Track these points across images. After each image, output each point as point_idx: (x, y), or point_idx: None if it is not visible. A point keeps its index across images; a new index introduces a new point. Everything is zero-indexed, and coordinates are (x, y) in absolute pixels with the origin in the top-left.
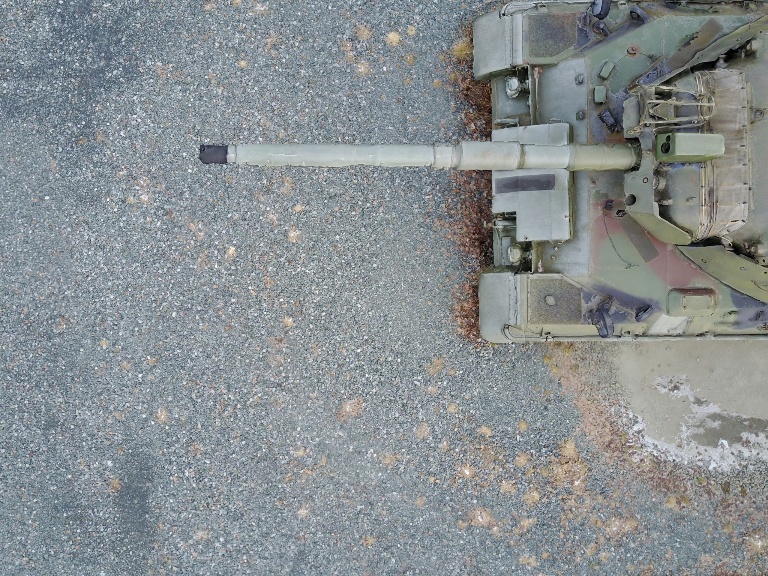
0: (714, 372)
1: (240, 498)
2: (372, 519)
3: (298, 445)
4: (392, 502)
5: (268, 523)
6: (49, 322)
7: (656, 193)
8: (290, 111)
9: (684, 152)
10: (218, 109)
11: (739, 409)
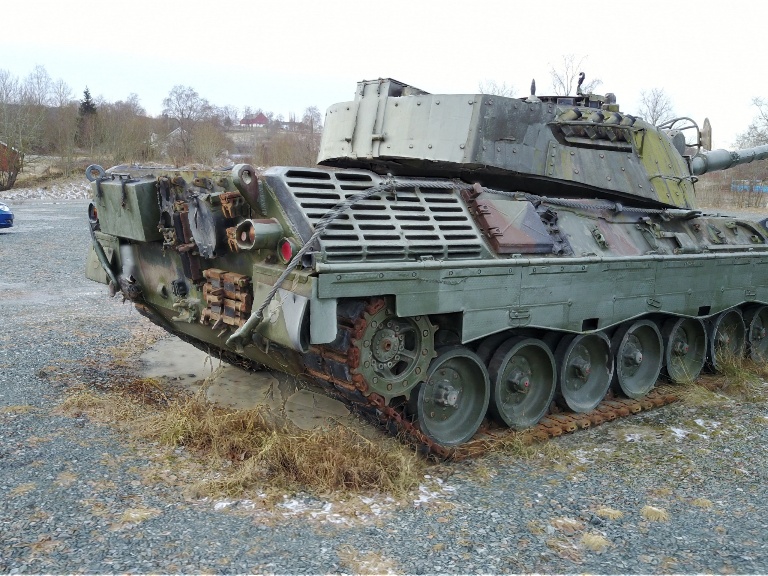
0: None
1: None
2: None
3: None
4: None
5: None
6: None
7: None
8: None
9: None
10: None
11: None
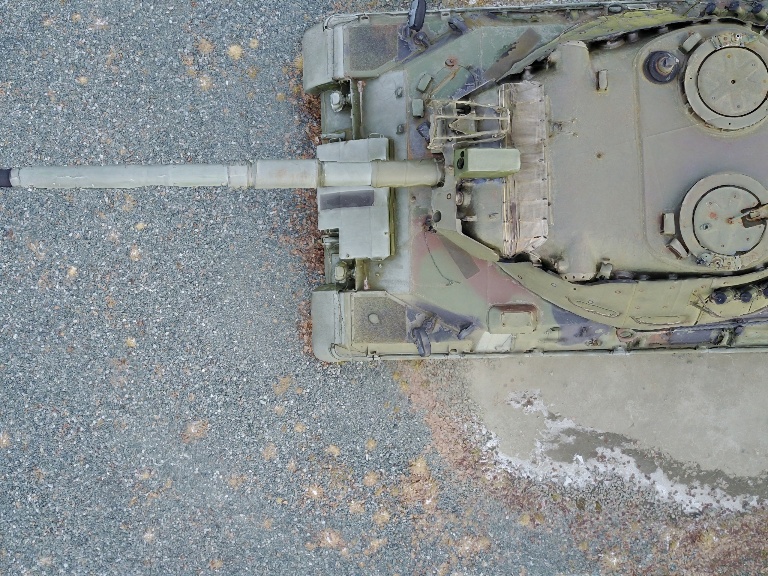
0: (568, 386)
1: (84, 523)
2: (219, 542)
3: (143, 468)
4: (239, 524)
5: (113, 548)
6: None
7: (463, 209)
8: (131, 127)
9: (477, 168)
10: (58, 126)
11: (594, 424)
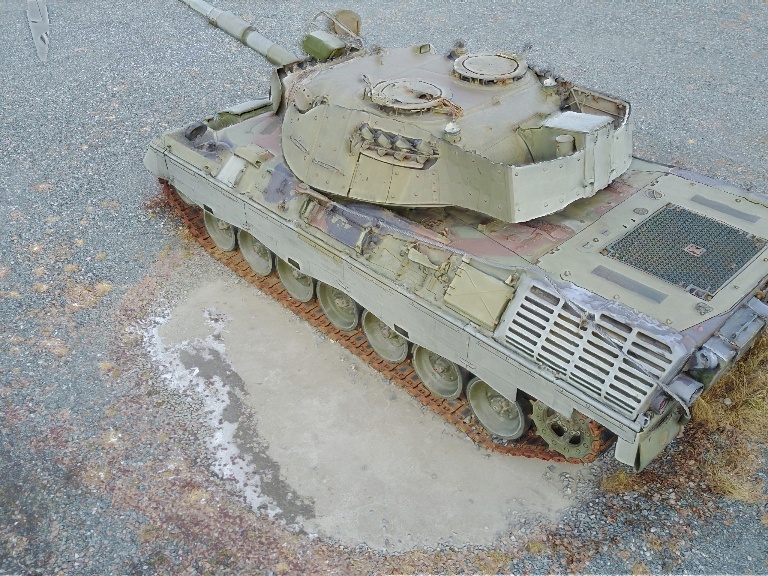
0: (253, 330)
1: None
2: None
3: None
4: None
5: None
6: (6, 91)
7: None
8: None
9: None
10: None
11: (237, 361)
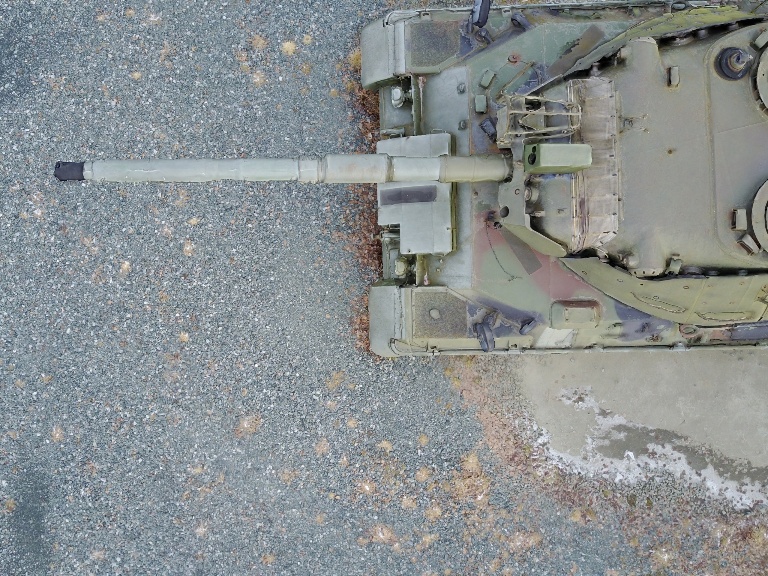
0: (619, 383)
1: (137, 517)
2: (272, 537)
3: (196, 462)
4: (292, 519)
5: (166, 542)
6: None
7: (530, 204)
8: (185, 123)
9: (549, 163)
10: (112, 122)
11: (645, 420)
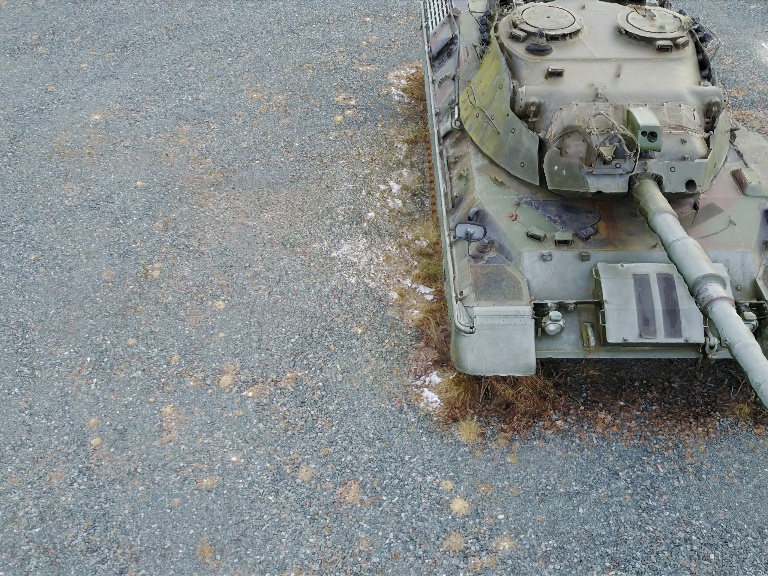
0: None
1: None
2: None
3: None
4: None
5: None
6: None
7: None
8: None
9: (657, 122)
10: None
11: None
